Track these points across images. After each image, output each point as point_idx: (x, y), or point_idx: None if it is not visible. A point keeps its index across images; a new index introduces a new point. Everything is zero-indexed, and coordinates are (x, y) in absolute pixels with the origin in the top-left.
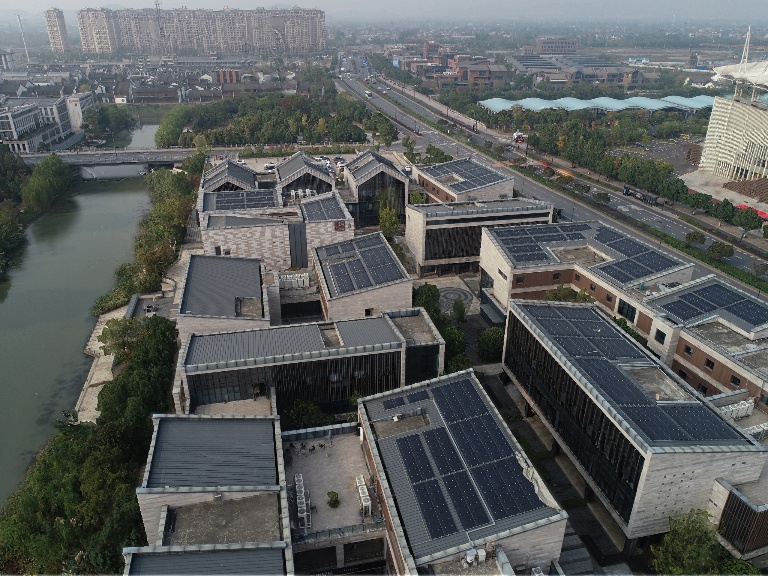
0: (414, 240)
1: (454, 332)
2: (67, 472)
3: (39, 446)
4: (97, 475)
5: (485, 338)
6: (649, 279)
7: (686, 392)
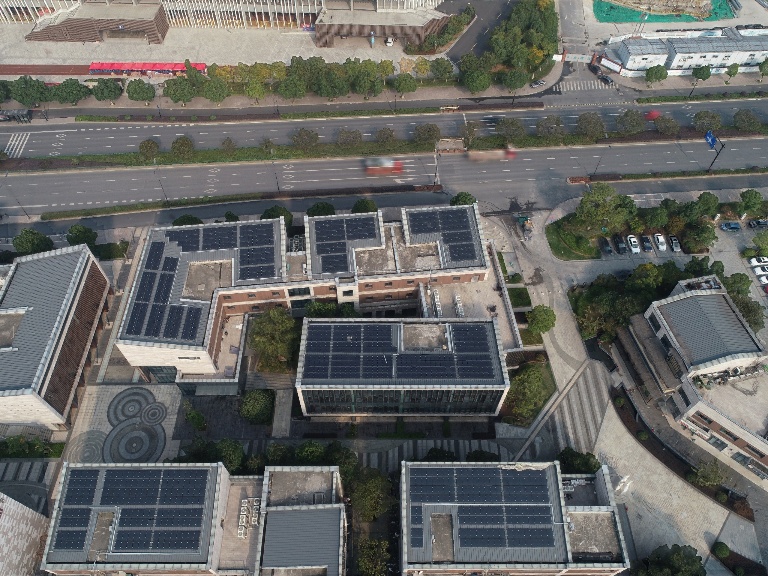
0: (19, 415)
1: (313, 451)
2: None
3: None
4: None
5: (256, 413)
6: (284, 257)
7: (433, 325)
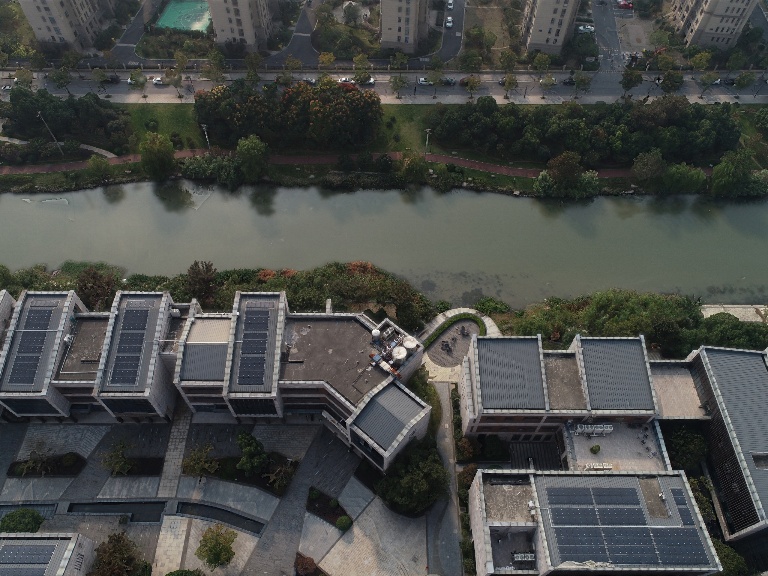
0: None
1: None
2: (650, 312)
3: (685, 294)
4: (629, 324)
5: None
6: None
7: None
